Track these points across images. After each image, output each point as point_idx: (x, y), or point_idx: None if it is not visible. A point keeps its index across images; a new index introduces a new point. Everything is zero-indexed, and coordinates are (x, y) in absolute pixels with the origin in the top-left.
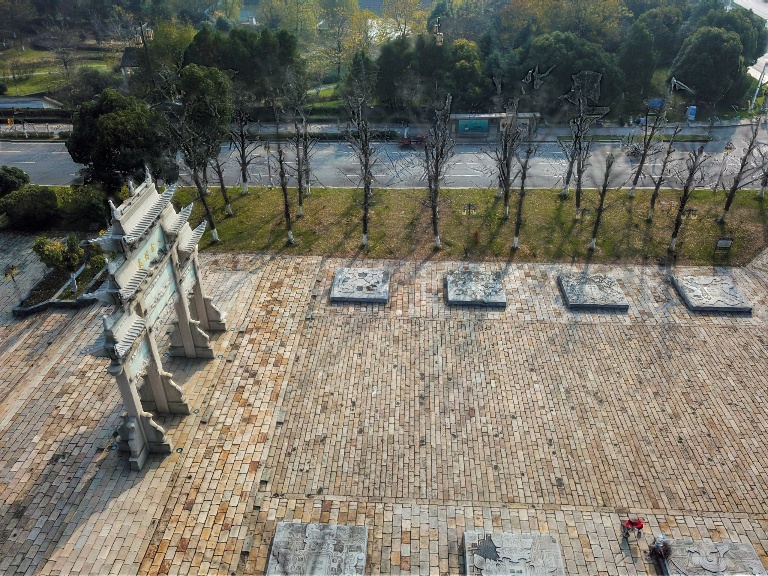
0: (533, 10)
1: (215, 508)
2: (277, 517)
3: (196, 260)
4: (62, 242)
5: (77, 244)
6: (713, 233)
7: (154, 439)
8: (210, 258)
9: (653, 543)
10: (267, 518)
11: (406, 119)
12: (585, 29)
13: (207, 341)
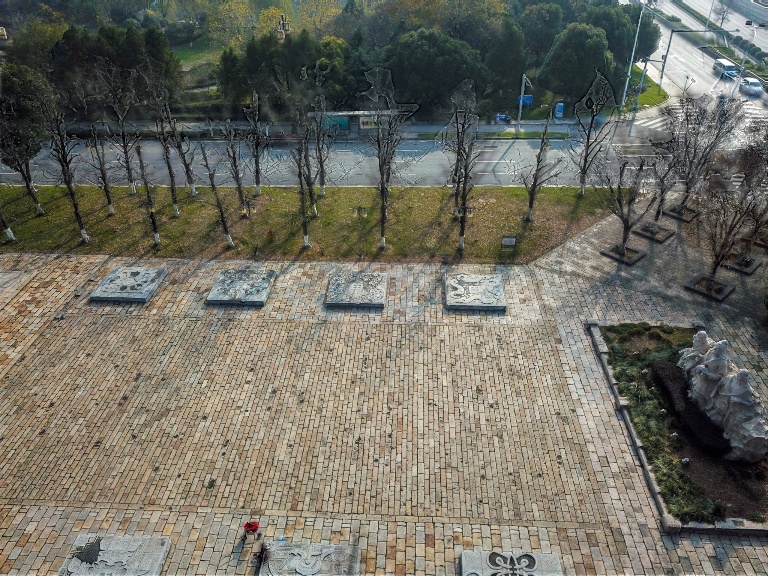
0: (417, 7)
1: None
2: None
3: None
4: None
5: None
6: (513, 231)
7: None
8: None
9: None
10: None
11: (276, 117)
12: (472, 26)
13: None
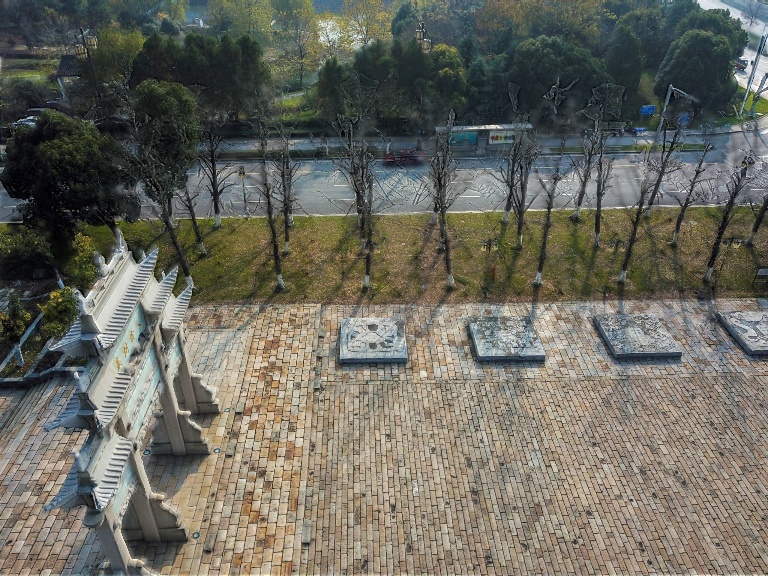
0: (510, 12)
1: None
2: None
3: (181, 333)
4: None
5: (21, 308)
6: (744, 258)
7: None
8: (187, 312)
9: None
10: None
11: (385, 132)
12: None
13: (200, 434)
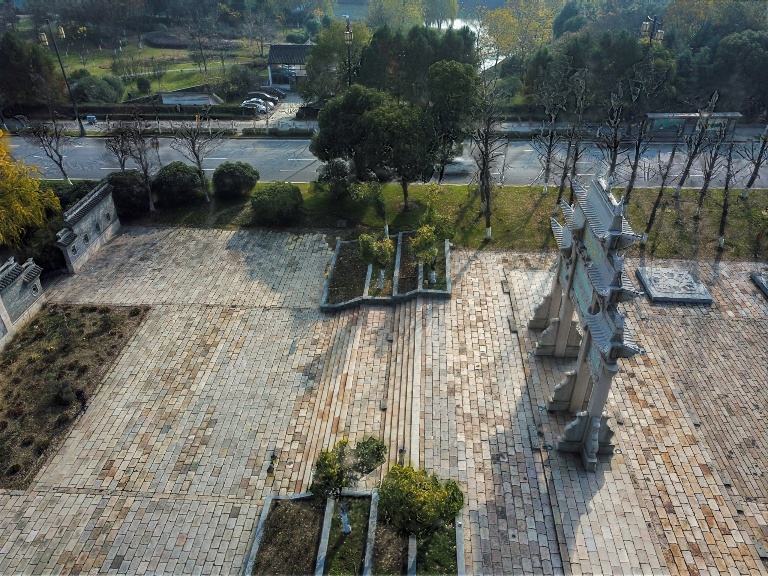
0: (699, 9)
1: (699, 512)
2: (767, 522)
3: None
4: (317, 239)
5: None
6: None
7: (602, 440)
8: (496, 256)
9: None
10: (758, 523)
11: (587, 118)
12: None
13: None
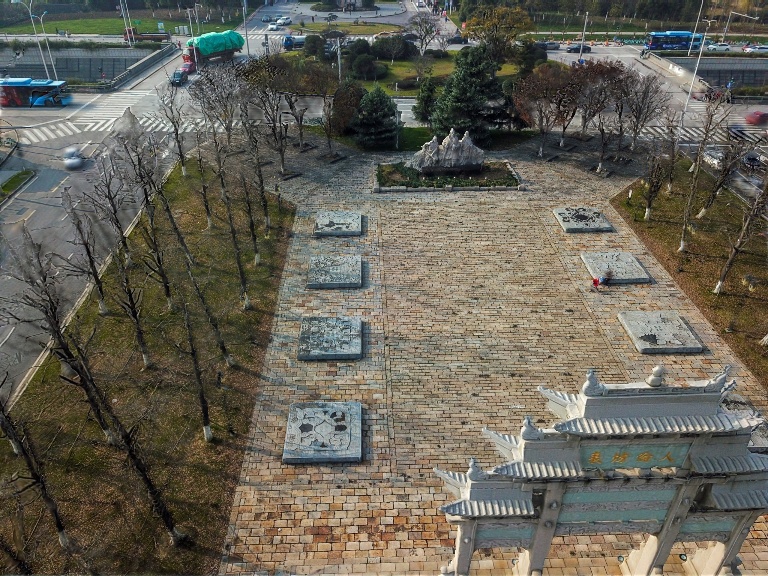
0: None
1: None
2: None
3: None
4: None
5: None
6: None
7: None
8: None
9: (598, 282)
10: None
11: None
12: None
13: None
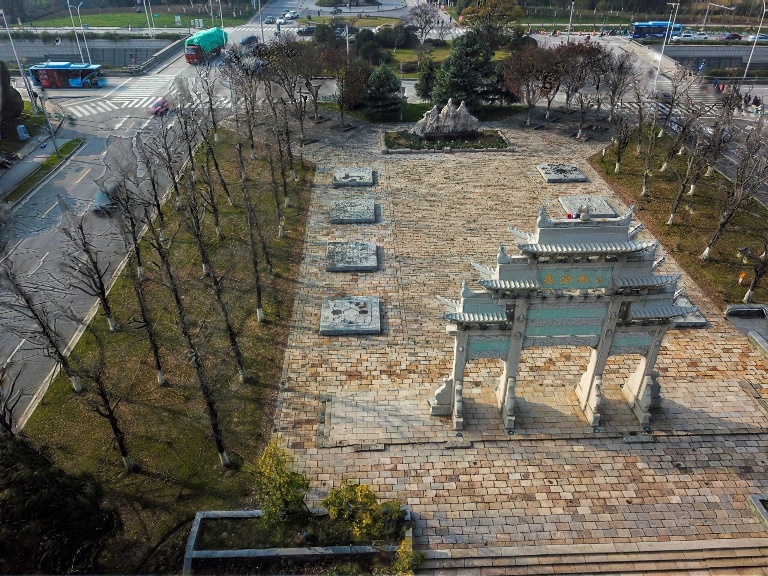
0: None
1: None
2: None
3: None
4: None
5: None
6: None
7: None
8: None
9: (572, 217)
10: None
11: None
12: None
13: None
